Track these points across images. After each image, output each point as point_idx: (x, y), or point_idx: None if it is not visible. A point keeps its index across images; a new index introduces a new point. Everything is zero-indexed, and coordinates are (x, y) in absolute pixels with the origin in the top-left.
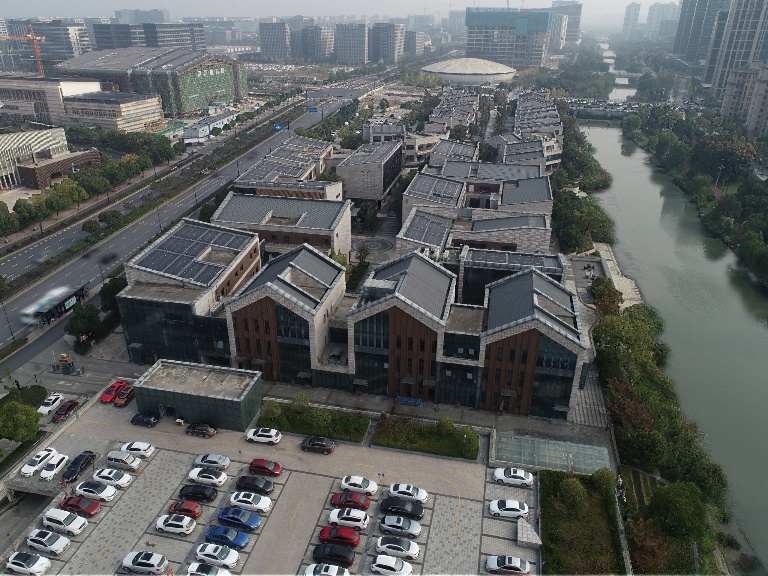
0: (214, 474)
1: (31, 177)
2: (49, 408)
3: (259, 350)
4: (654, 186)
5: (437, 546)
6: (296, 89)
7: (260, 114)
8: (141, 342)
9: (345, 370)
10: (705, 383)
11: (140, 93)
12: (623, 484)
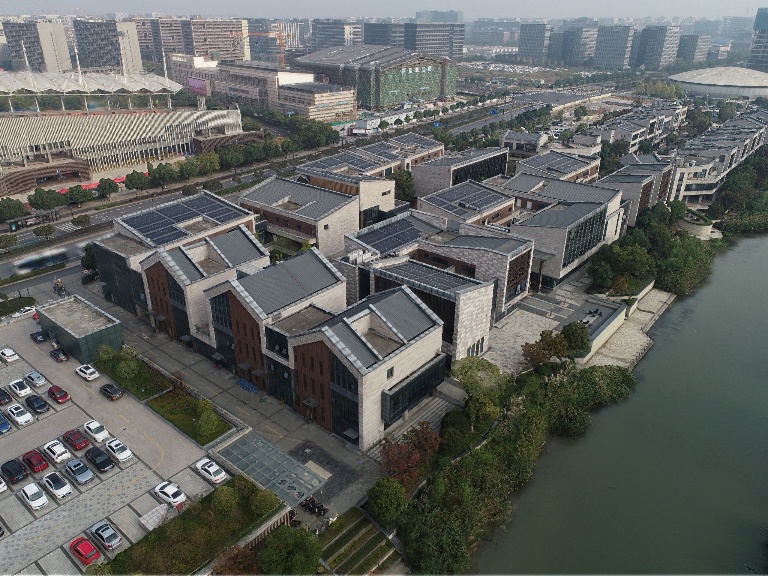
0: (21, 387)
1: (199, 147)
2: None
3: (162, 308)
4: None
5: (86, 498)
6: (504, 91)
7: (446, 112)
8: (107, 282)
9: (209, 342)
10: (602, 473)
11: (341, 85)
12: (332, 524)
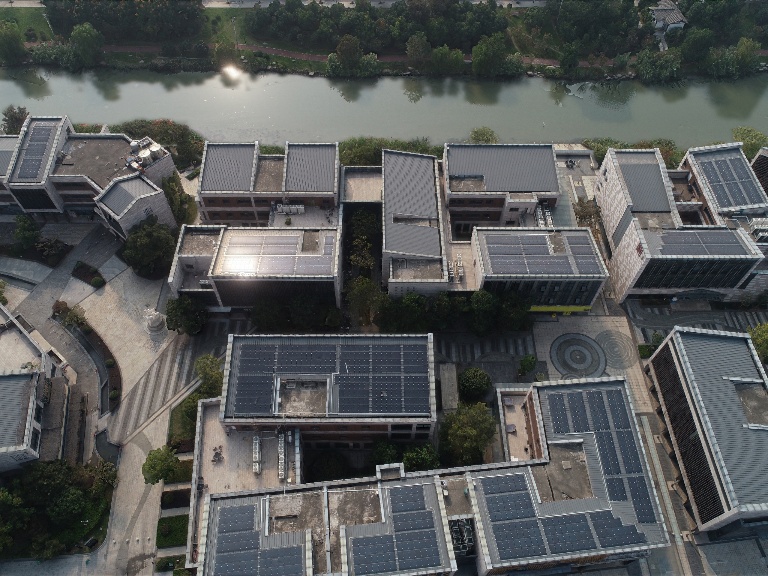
0: None
1: None
2: None
3: None
4: (179, 91)
5: None
6: None
7: None
8: None
9: None
10: (673, 134)
11: None
12: None
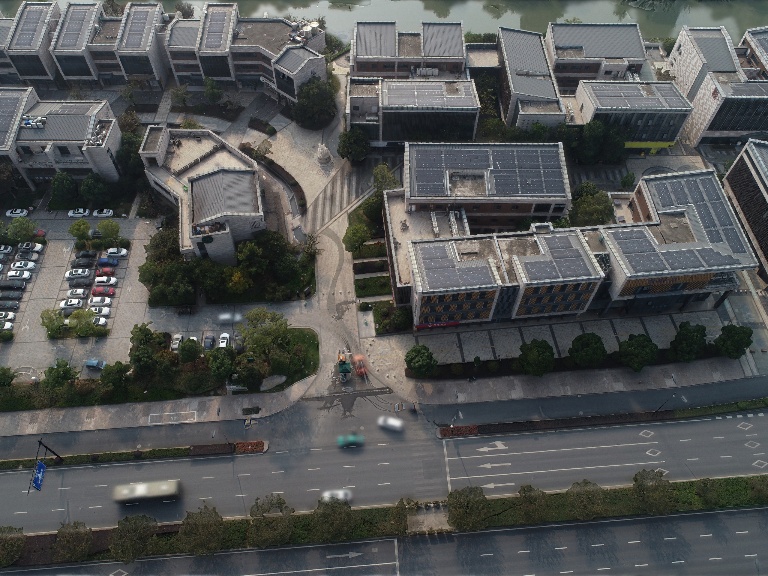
0: None
1: None
2: None
3: None
4: (302, 3)
5: None
6: None
7: None
8: None
9: None
10: None
11: None
12: None
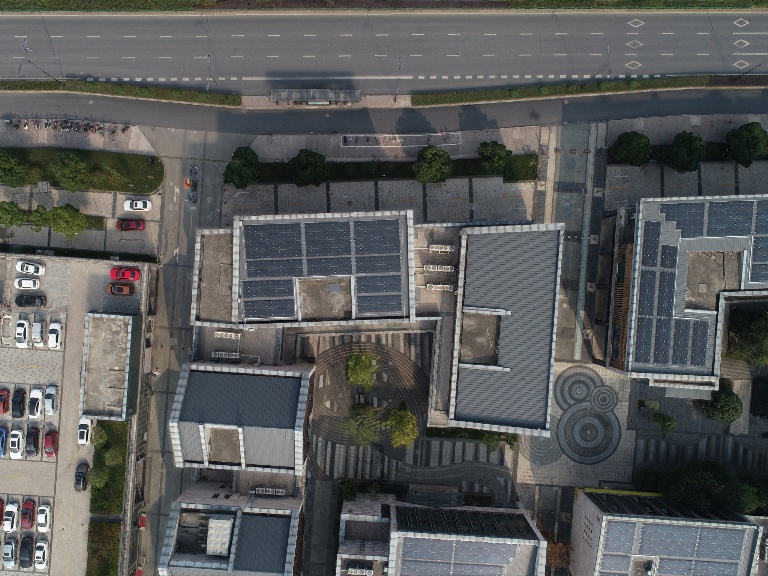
0: (31, 411)
1: None
2: (130, 209)
3: None
4: None
5: None
6: None
7: None
8: None
9: None
10: None
11: None
12: None
